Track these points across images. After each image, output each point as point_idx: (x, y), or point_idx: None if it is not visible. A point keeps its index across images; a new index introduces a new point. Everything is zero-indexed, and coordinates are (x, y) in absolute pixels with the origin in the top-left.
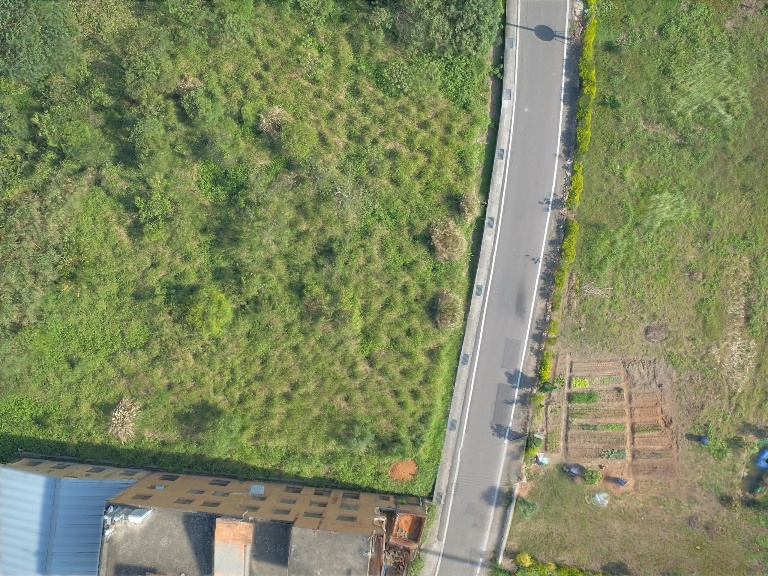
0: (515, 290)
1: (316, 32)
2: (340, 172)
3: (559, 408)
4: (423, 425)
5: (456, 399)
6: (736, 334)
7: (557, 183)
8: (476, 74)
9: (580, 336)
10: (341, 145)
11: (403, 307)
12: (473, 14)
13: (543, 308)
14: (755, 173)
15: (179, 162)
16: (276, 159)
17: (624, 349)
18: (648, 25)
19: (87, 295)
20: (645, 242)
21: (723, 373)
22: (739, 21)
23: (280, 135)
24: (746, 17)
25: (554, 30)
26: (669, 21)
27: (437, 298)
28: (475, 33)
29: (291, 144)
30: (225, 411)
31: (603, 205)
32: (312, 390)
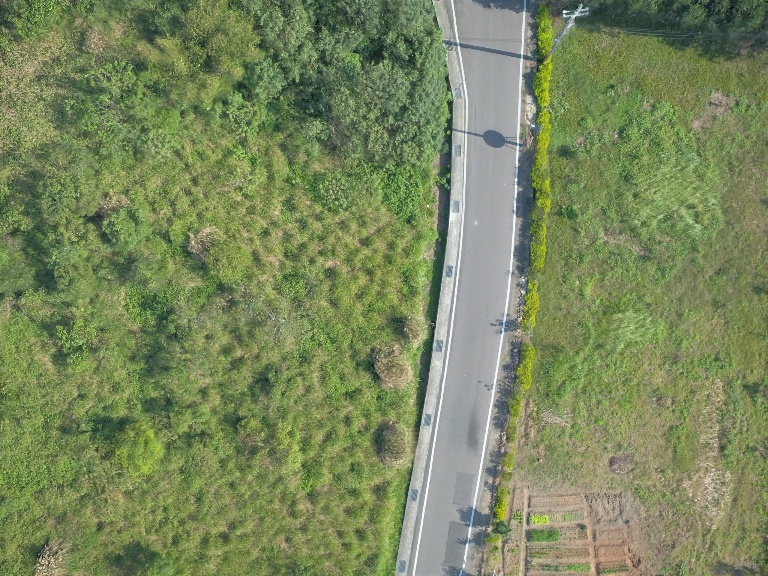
0: (467, 419)
1: (248, 144)
2: (277, 293)
3: (517, 547)
4: (368, 568)
5: (405, 538)
6: (709, 465)
7: (510, 302)
8: (421, 185)
9: (538, 468)
10: (277, 265)
11: (345, 440)
12: (413, 126)
13: (497, 439)
14: (728, 287)
15: (105, 286)
16: (208, 280)
17: (587, 482)
18: (608, 127)
19: (11, 429)
20: (608, 365)
21: (696, 508)
22: (708, 120)
23: (209, 259)
24: (715, 116)
25: (505, 136)
26: (631, 122)
27: (382, 429)
28: (417, 144)
29: (221, 269)
30: (157, 553)
31: (561, 325)
32: (249, 530)
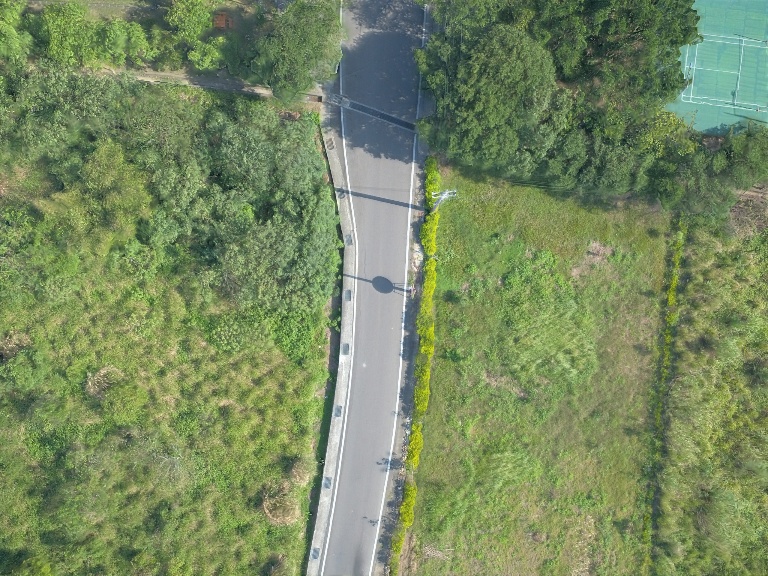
0: (353, 553)
1: (145, 286)
2: (173, 430)
3: None
4: None
5: None
6: None
7: (396, 442)
8: (313, 327)
9: None
10: (173, 403)
11: (236, 573)
12: (301, 278)
13: (381, 572)
14: (601, 429)
15: (5, 422)
16: None
17: None
18: (491, 274)
19: None
20: (487, 502)
21: None
22: (586, 269)
23: (104, 402)
24: (593, 265)
25: (393, 282)
26: (513, 270)
27: (272, 562)
28: (306, 293)
29: (115, 412)
30: None
31: (444, 463)
32: None
